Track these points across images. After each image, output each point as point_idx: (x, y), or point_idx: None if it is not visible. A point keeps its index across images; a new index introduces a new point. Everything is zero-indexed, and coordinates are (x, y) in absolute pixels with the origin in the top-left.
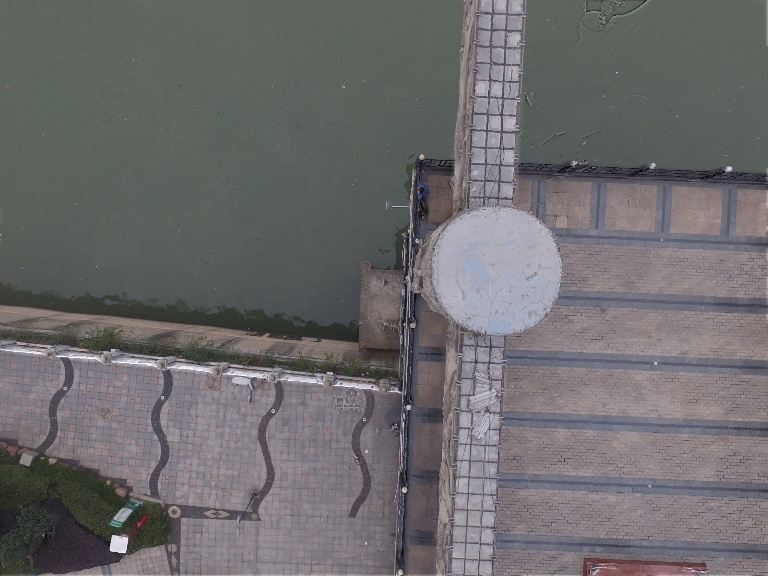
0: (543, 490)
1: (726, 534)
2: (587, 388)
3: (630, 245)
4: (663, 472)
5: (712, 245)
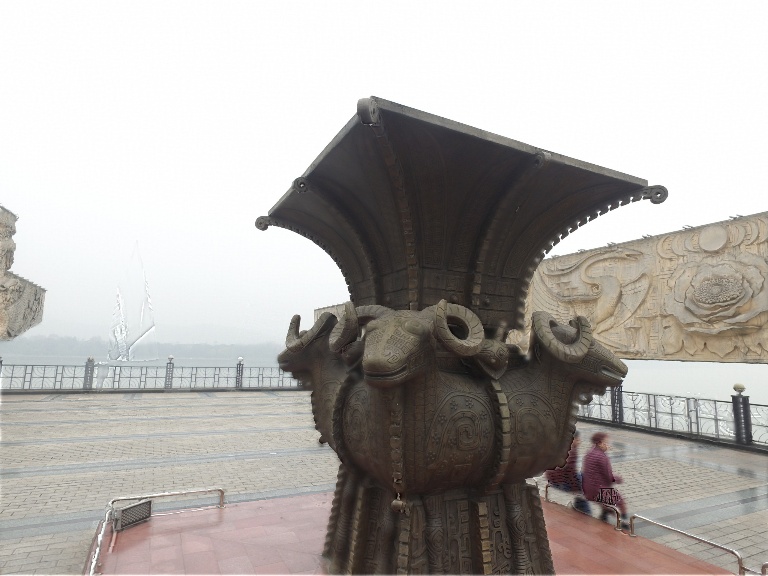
0: None
1: None
2: (117, 427)
3: (174, 399)
4: (291, 445)
5: (265, 397)
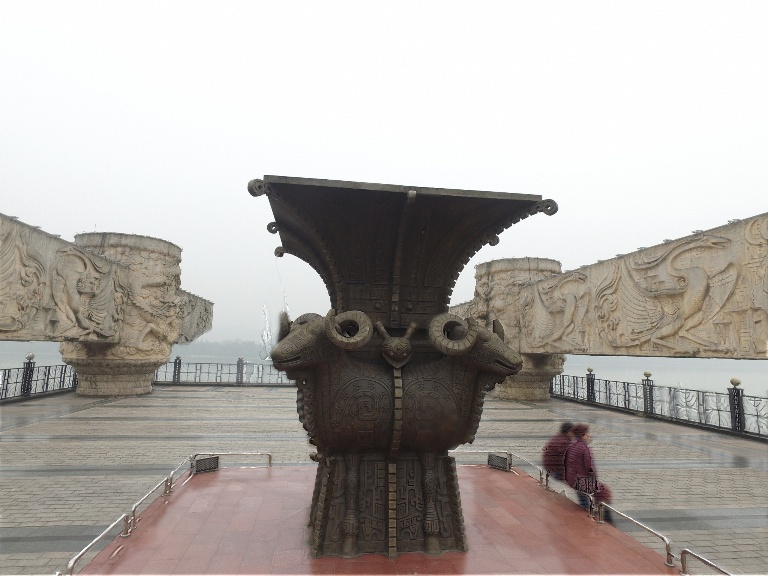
0: (128, 441)
1: (523, 456)
2: None
3: None
4: None
5: None
